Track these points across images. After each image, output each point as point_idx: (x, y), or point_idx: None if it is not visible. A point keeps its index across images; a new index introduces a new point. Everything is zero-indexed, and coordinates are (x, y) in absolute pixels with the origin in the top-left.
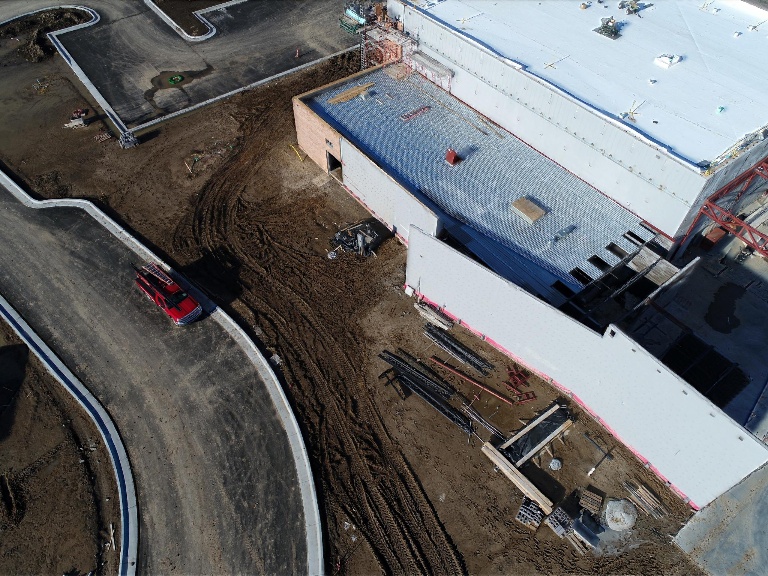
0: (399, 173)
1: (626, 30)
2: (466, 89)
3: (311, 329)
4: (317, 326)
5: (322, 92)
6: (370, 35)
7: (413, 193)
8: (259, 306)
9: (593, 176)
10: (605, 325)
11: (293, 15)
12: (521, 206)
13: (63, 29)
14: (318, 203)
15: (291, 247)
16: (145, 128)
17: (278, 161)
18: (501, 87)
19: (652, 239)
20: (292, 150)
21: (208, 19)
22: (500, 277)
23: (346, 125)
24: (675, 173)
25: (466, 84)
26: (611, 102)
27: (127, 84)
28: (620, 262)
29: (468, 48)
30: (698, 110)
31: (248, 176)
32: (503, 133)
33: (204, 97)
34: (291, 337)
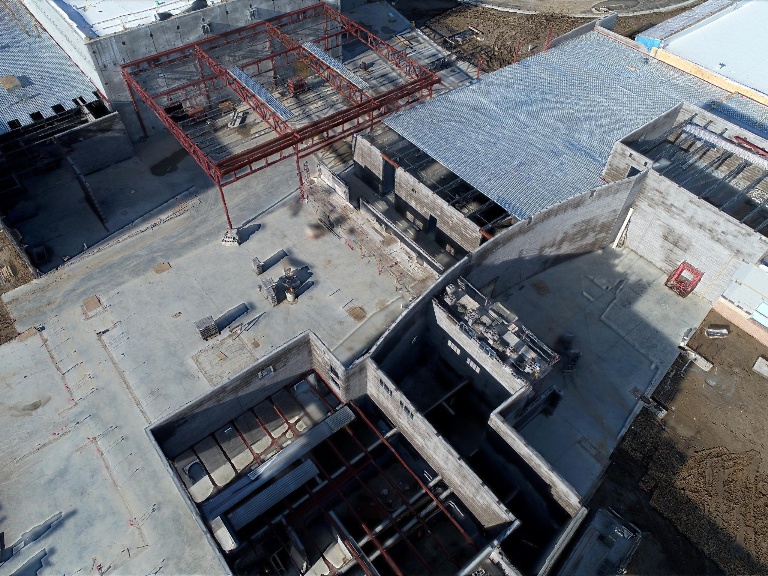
0: None
1: None
2: (27, 2)
3: None
4: None
5: None
6: None
7: None
8: None
9: (76, 60)
10: (3, 153)
11: None
12: (5, 80)
13: None
14: None
15: None
16: None
17: None
18: None
19: (93, 101)
20: None
21: None
22: None
23: None
24: (80, 43)
25: None
26: None
27: None
28: (55, 116)
29: None
30: (143, 4)
31: None
32: (44, 35)
33: None
34: None
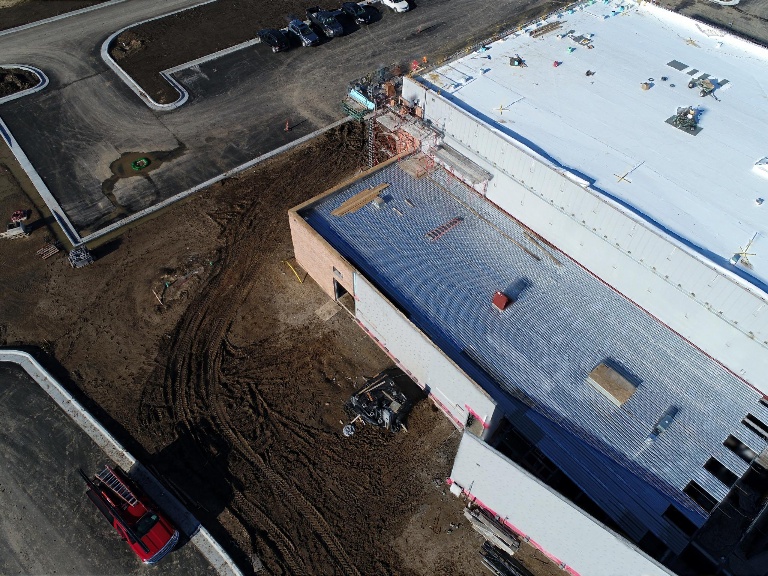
0: (434, 324)
1: (706, 120)
2: (508, 197)
3: (329, 558)
4: (336, 553)
5: (325, 199)
6: (382, 123)
7: (456, 357)
8: (256, 520)
9: (690, 329)
10: None
11: (279, 73)
12: (603, 379)
13: (3, 97)
14: (325, 347)
15: (294, 419)
16: (102, 236)
17: (271, 283)
18: (559, 204)
19: None
20: (288, 266)
21: (178, 80)
22: (603, 526)
23: (359, 249)
24: None
25: (508, 191)
26: (713, 236)
27: (80, 172)
28: (747, 468)
29: (514, 152)
30: None
31: (234, 306)
32: (560, 257)
33: (176, 189)
34: (302, 573)
